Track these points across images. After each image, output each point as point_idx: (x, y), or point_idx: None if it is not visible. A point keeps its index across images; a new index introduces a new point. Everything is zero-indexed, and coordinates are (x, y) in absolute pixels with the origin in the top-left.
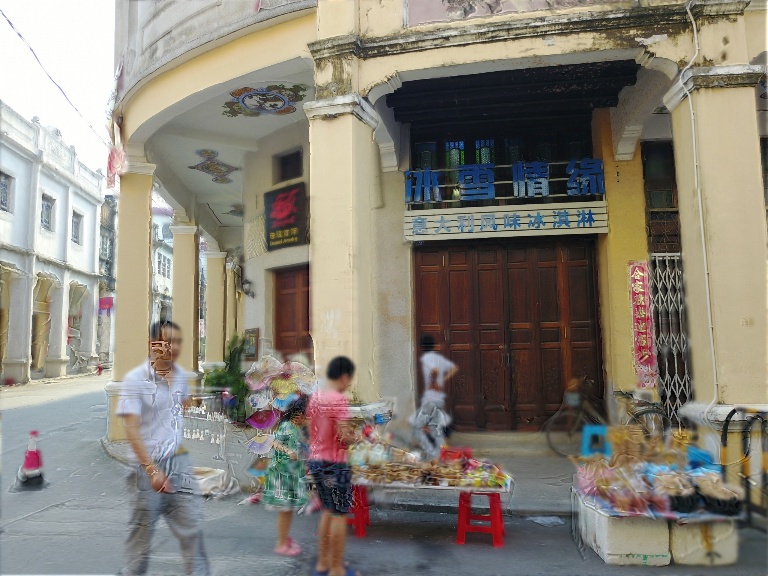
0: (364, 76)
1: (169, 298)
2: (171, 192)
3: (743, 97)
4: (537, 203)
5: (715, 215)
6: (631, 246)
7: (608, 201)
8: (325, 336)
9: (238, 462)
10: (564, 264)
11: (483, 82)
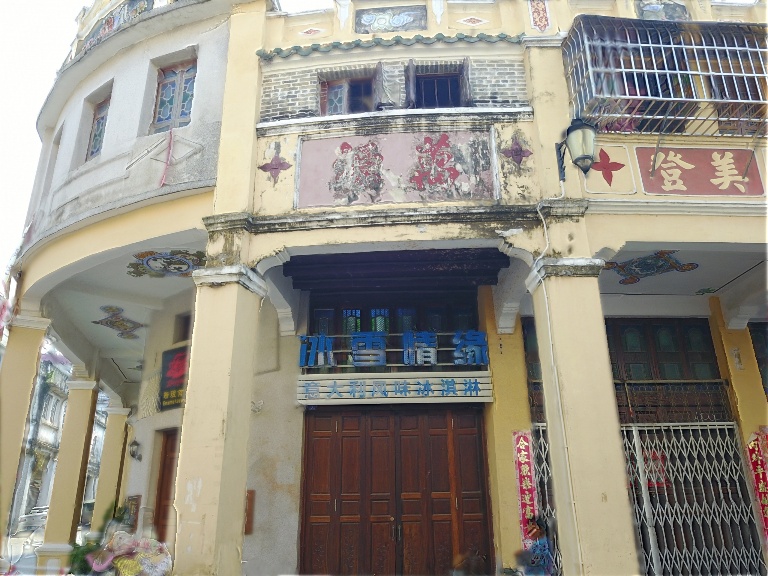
0: (254, 249)
1: None
2: (70, 346)
3: (588, 285)
4: (426, 371)
5: (570, 391)
6: (515, 416)
7: (493, 371)
8: (190, 509)
9: None
10: (455, 432)
11: (373, 258)
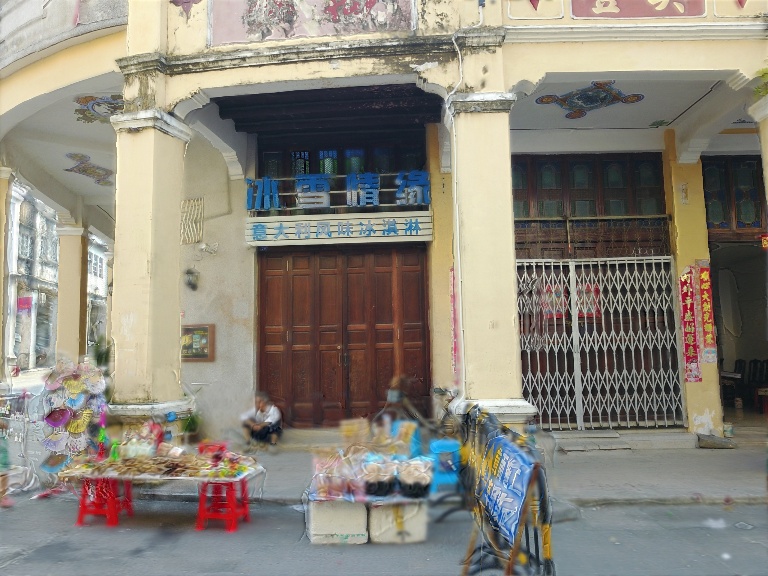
0: (170, 92)
1: (101, 298)
2: (49, 194)
3: (498, 122)
4: (369, 212)
5: (469, 228)
6: None
7: (434, 211)
8: (124, 338)
9: (38, 459)
10: (399, 269)
11: (307, 98)
